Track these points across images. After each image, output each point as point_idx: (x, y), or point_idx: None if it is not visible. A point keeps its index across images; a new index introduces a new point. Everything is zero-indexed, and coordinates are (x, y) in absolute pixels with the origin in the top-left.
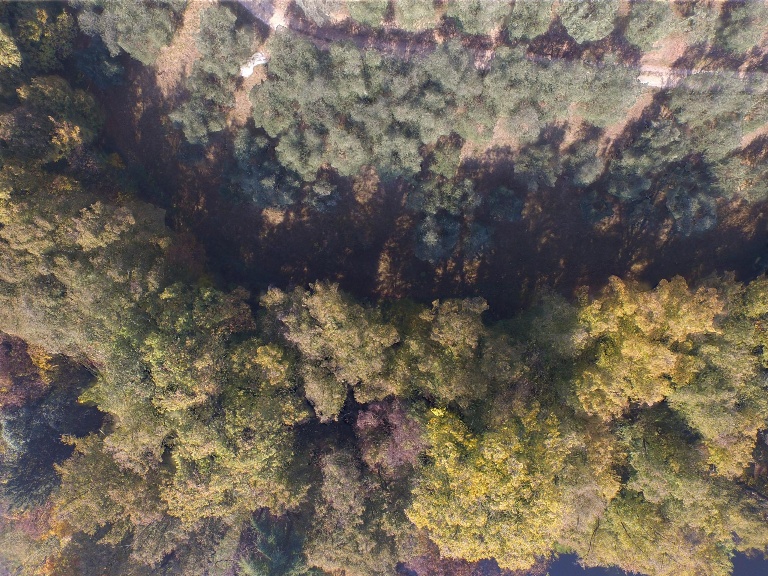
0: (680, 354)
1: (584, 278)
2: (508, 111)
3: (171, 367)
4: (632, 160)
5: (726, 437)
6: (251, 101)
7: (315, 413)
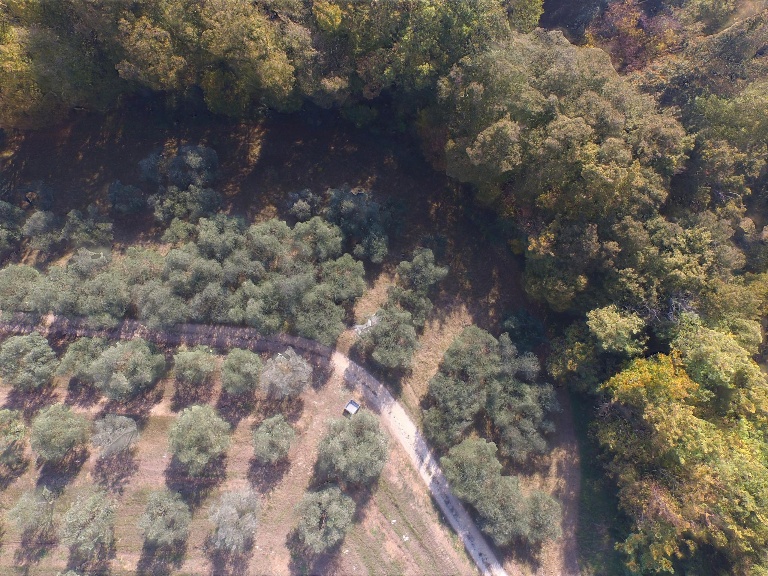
0: None
1: (61, 144)
2: None
3: None
4: None
5: None
6: (363, 282)
7: None
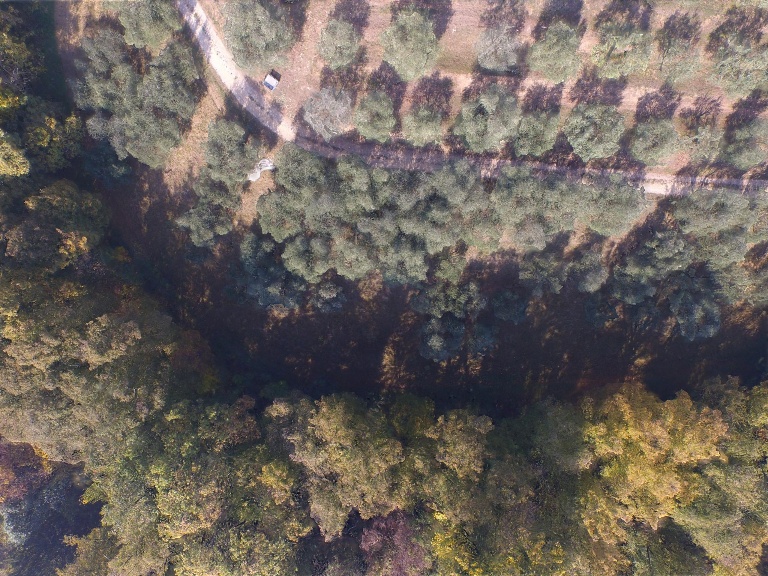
0: (684, 472)
1: (588, 371)
2: (514, 224)
3: (176, 496)
4: (637, 270)
5: (730, 557)
6: (258, 210)
7: (319, 530)
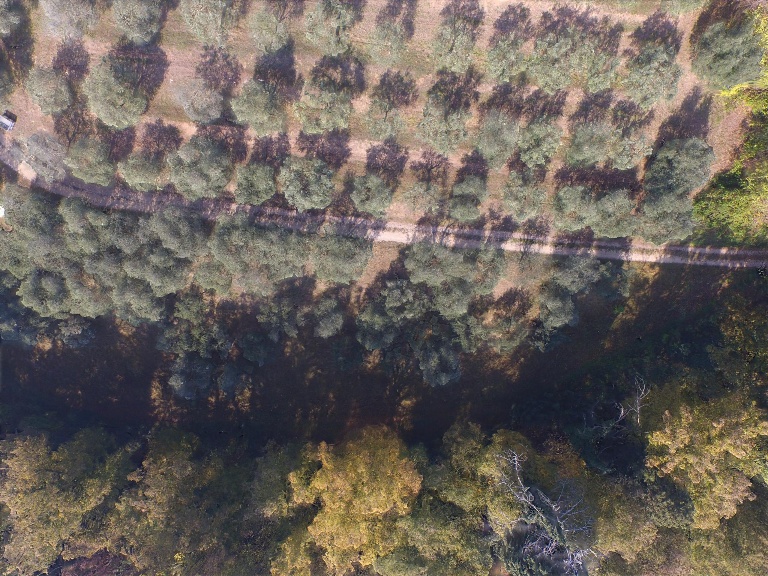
0: (386, 521)
1: (356, 411)
2: (238, 270)
3: None
4: (367, 317)
5: None
6: None
7: (19, 570)
